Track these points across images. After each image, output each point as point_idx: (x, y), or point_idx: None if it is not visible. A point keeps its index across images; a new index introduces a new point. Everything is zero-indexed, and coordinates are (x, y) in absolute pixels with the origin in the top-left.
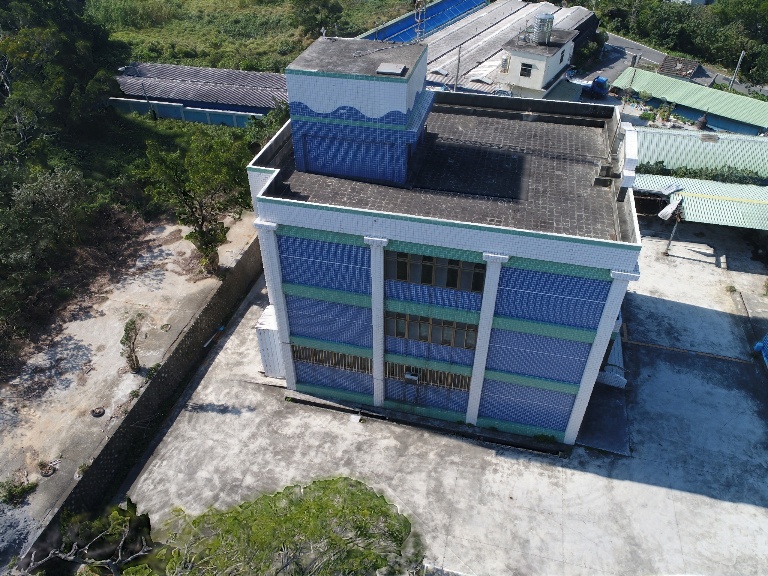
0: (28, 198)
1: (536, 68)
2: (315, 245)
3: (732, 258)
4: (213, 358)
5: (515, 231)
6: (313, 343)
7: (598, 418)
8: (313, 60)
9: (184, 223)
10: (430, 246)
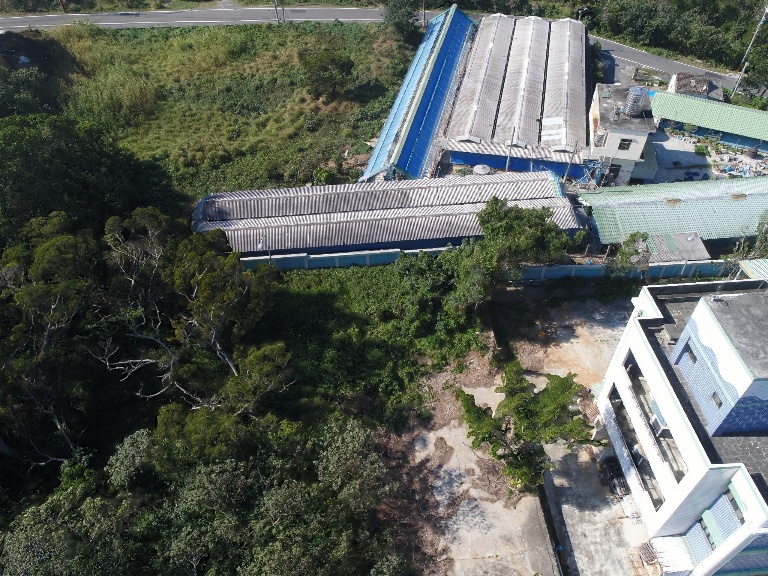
0: None
1: (636, 142)
2: None
3: None
4: None
5: None
6: (730, 575)
7: None
8: (757, 353)
9: (501, 458)
10: None
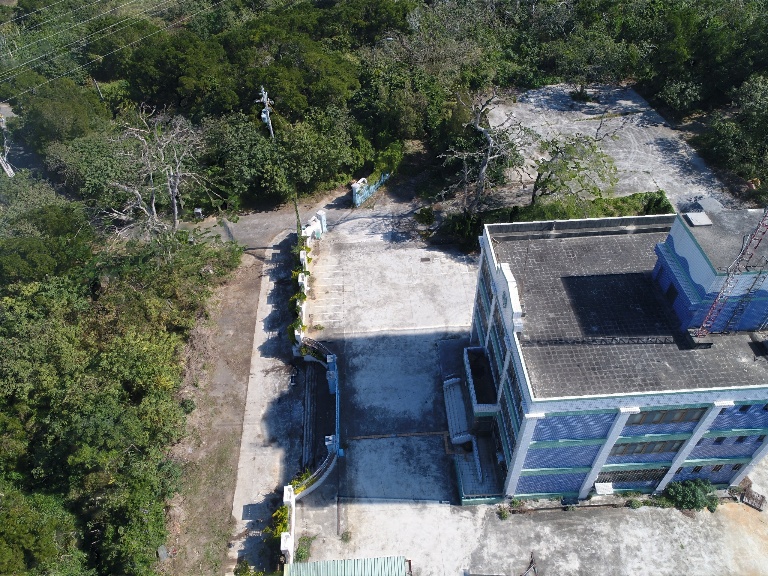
0: None
1: None
2: None
3: None
4: None
5: None
6: None
7: (458, 357)
8: None
9: None
10: None
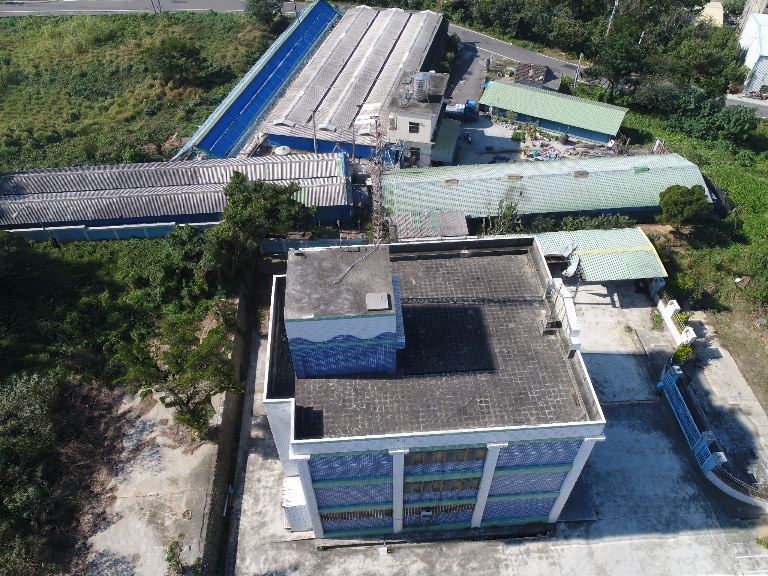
0: (8, 432)
1: (423, 126)
2: (342, 457)
3: (622, 295)
4: (237, 525)
5: (512, 429)
6: (340, 510)
7: None
8: (302, 298)
9: (170, 406)
10: (444, 445)
